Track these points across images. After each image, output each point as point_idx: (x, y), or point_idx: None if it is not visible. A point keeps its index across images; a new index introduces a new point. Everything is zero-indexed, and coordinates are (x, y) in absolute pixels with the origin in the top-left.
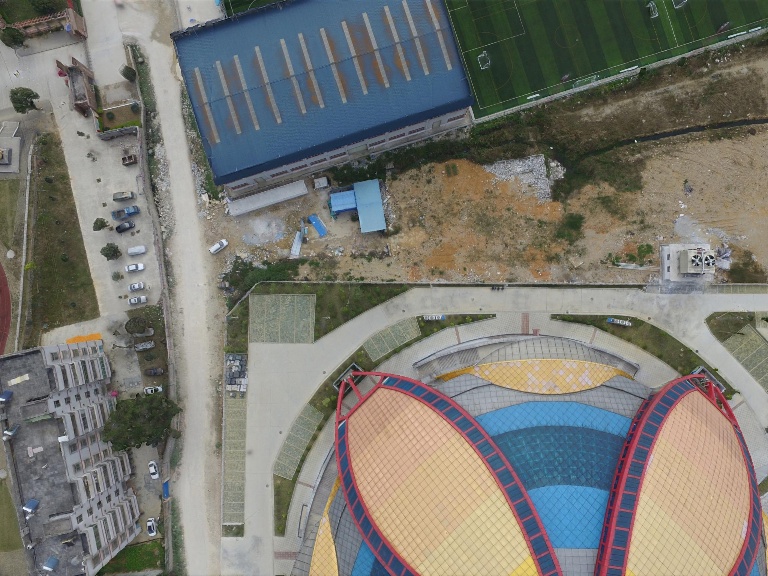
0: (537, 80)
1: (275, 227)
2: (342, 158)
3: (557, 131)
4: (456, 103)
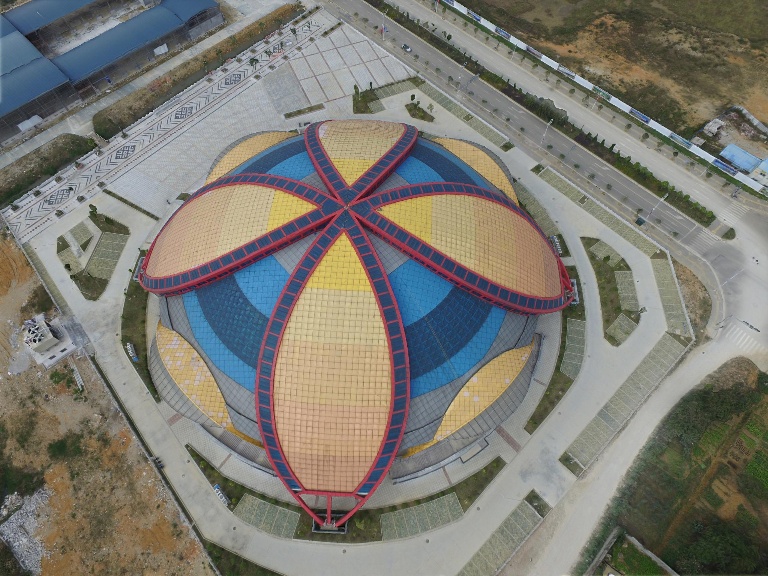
0: None
1: None
2: None
3: None
4: None
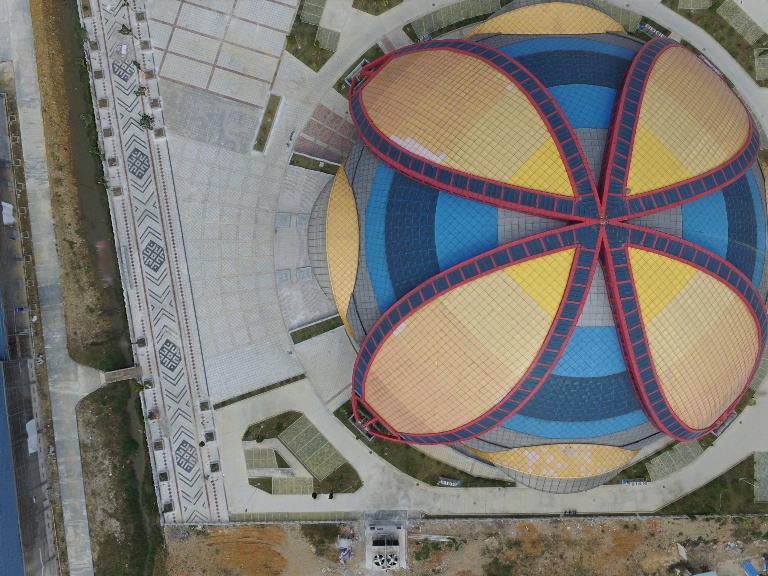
0: None
1: None
2: None
3: None
4: None
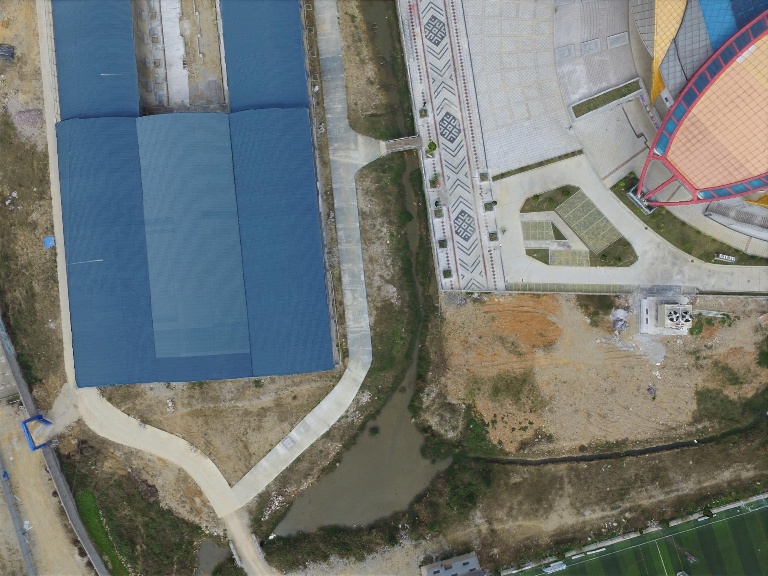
0: None
1: None
2: None
3: None
4: None
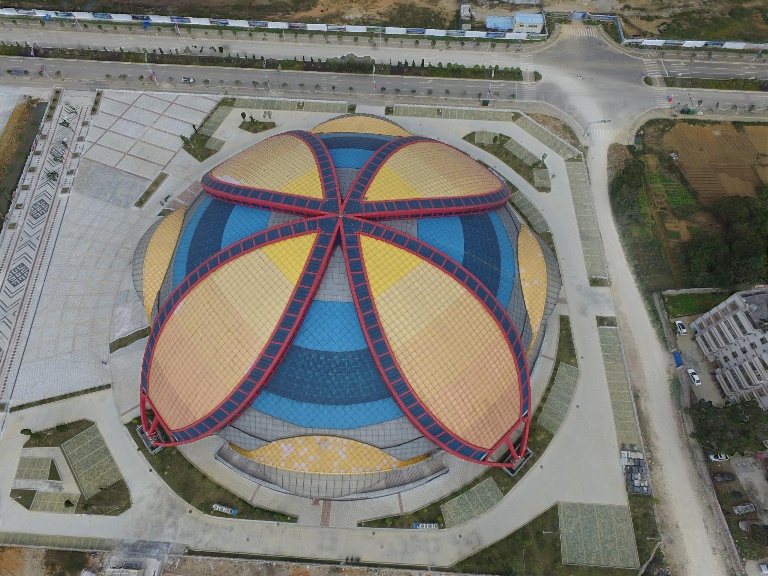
0: None
1: None
2: None
3: None
4: None
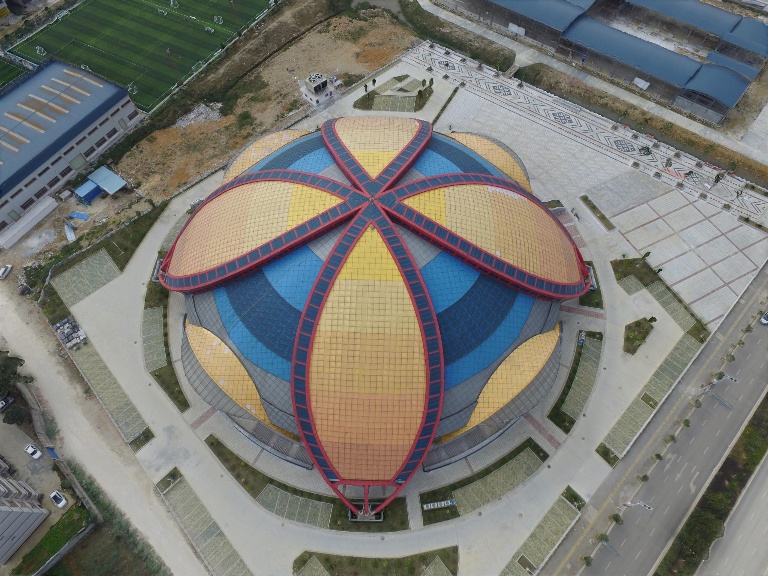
0: (171, 81)
1: (46, 235)
2: (72, 175)
3: (201, 91)
4: (116, 95)
